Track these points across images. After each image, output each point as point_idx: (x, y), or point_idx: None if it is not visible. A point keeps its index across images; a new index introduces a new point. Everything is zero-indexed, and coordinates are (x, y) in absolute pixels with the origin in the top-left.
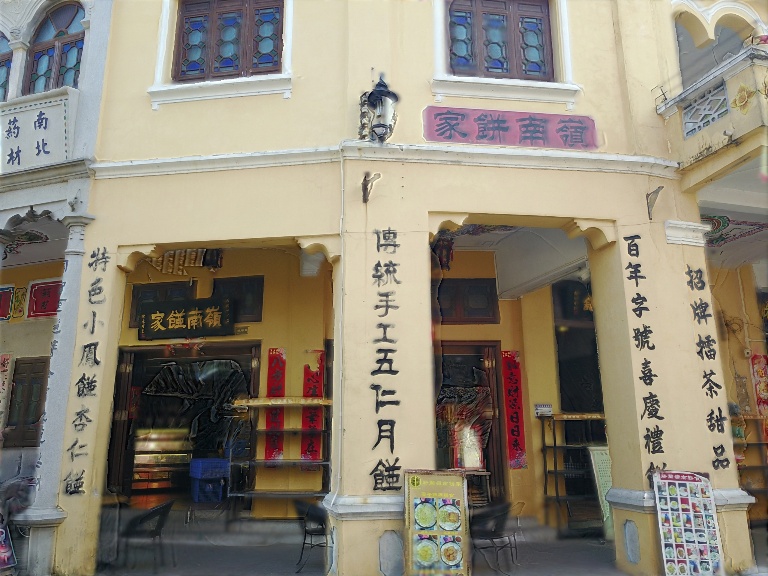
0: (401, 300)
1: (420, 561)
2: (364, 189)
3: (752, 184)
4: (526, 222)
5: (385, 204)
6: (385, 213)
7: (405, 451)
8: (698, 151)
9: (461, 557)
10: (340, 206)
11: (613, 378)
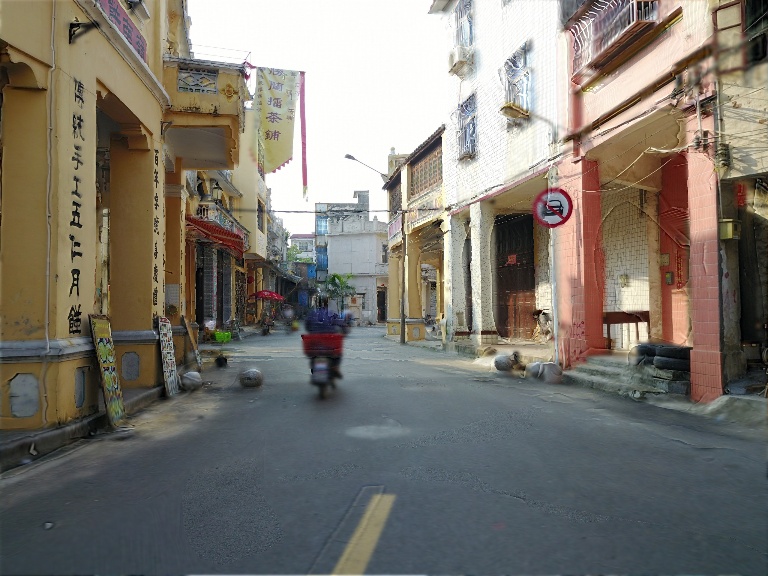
0: (84, 157)
1: (107, 387)
2: (70, 29)
3: (174, 131)
4: (121, 113)
5: (77, 53)
6: (78, 63)
7: (83, 299)
8: (189, 106)
9: (117, 382)
10: (50, 34)
11: (127, 250)
